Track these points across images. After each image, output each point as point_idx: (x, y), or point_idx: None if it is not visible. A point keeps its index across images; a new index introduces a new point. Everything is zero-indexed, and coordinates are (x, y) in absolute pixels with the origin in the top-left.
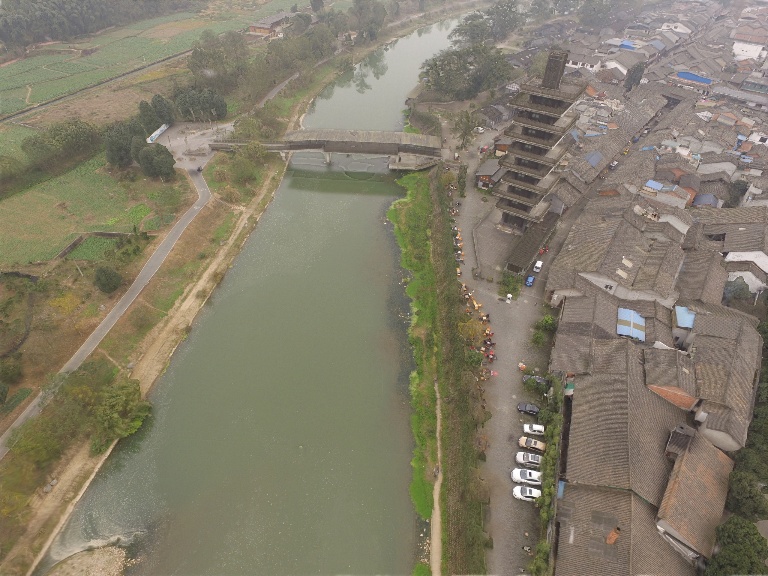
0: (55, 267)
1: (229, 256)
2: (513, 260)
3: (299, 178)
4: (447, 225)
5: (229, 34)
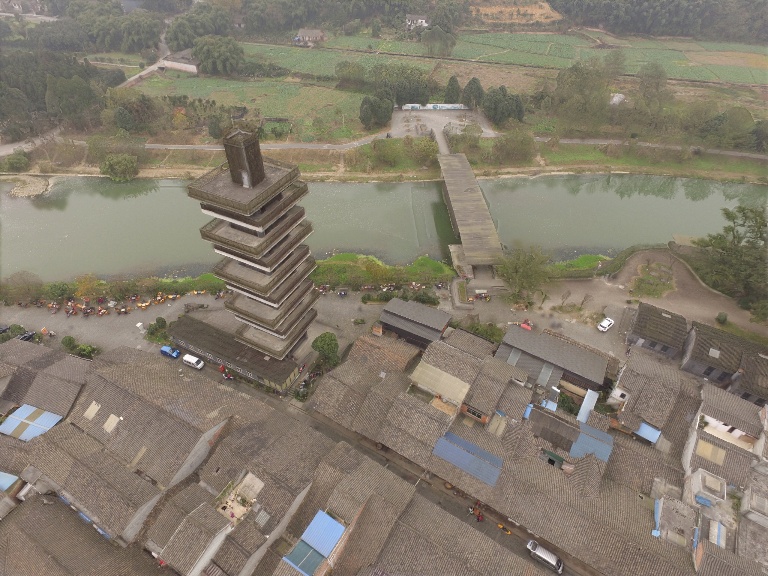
0: (251, 119)
1: None
2: (182, 320)
3: (409, 190)
4: None
5: (653, 66)
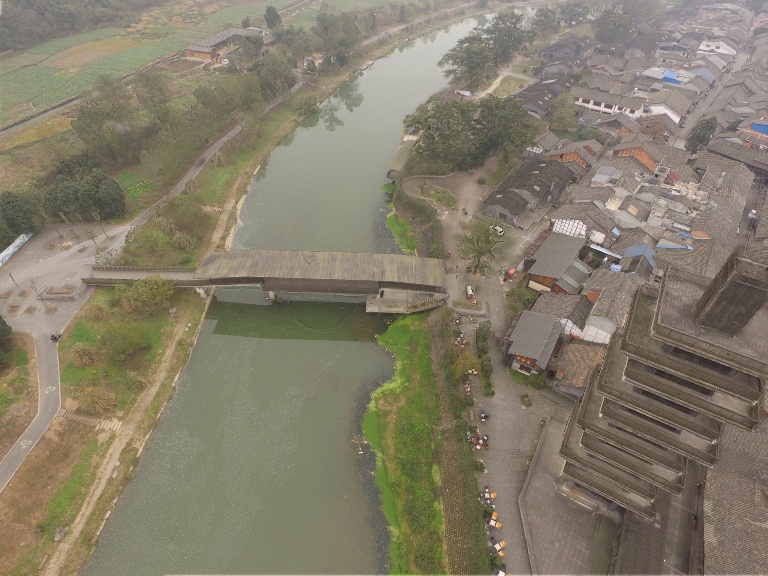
0: None
1: (65, 575)
2: None
3: (223, 338)
4: (471, 487)
5: (140, 76)
